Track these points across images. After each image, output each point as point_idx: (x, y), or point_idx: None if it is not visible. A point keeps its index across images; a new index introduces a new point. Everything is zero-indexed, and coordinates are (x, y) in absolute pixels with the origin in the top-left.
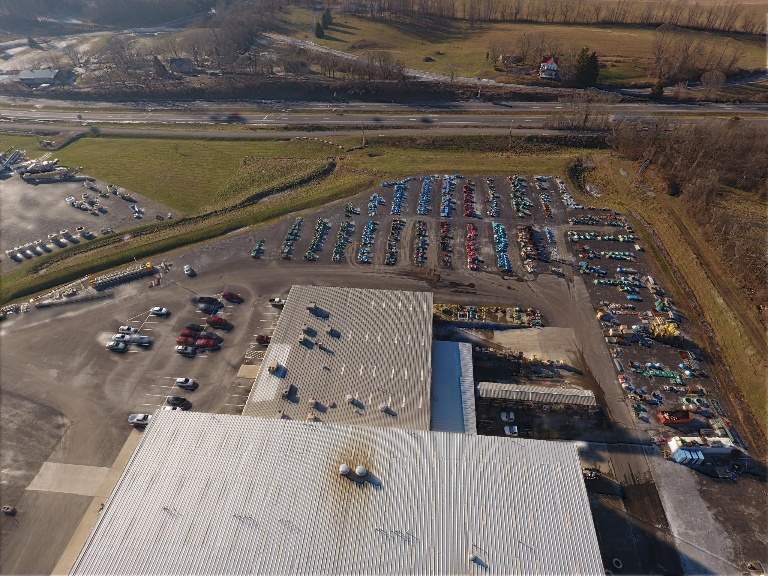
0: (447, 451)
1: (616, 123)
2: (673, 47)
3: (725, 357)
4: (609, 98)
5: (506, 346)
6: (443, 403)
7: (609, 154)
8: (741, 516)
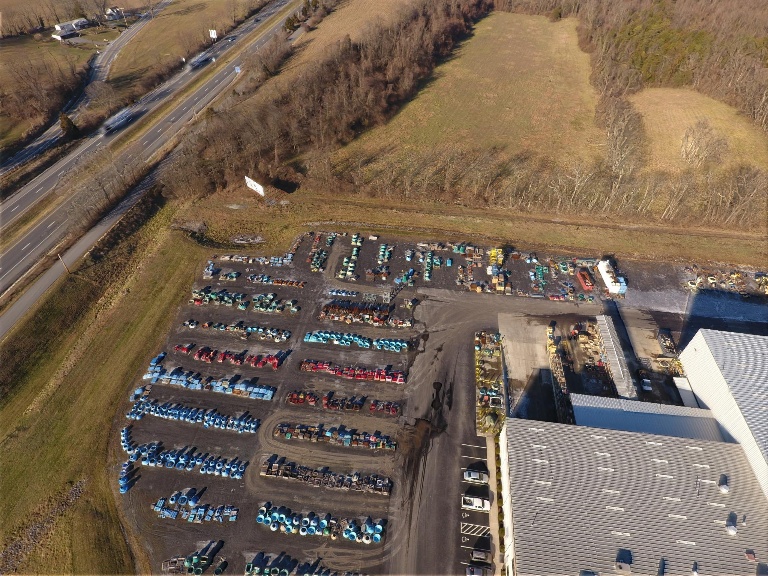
0: (766, 421)
1: (130, 176)
2: (9, 78)
3: (510, 238)
4: (104, 156)
5: (531, 371)
6: (666, 431)
7: (181, 205)
8: (652, 279)
